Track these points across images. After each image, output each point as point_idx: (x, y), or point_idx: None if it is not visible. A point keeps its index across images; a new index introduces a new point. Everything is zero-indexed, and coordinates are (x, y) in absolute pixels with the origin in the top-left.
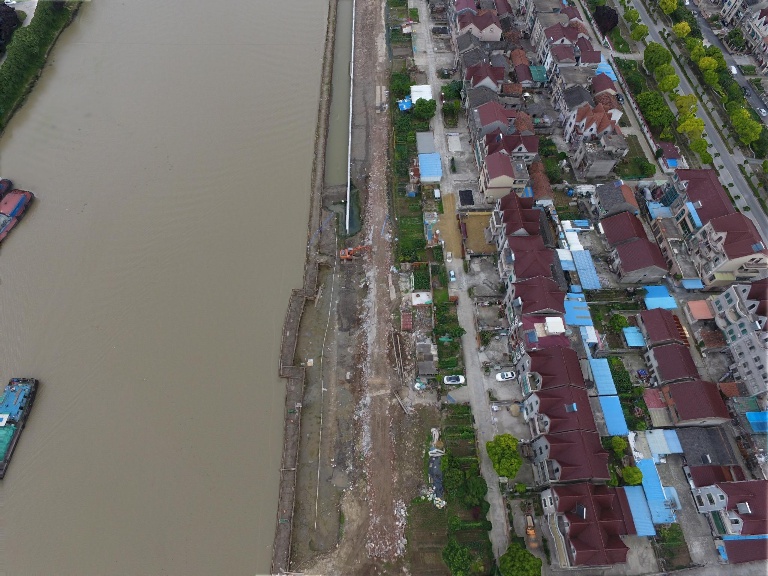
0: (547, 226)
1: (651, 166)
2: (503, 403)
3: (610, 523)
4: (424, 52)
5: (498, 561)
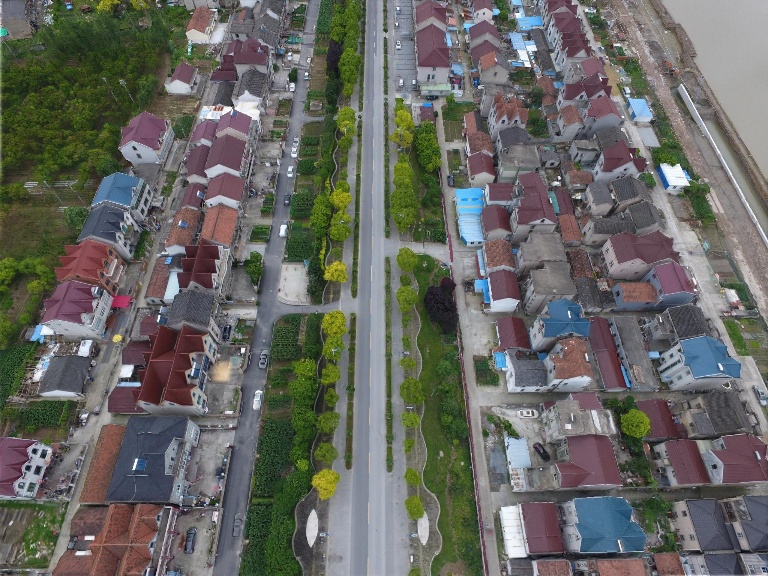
0: (544, 61)
1: None
2: None
3: None
4: (692, 252)
5: None
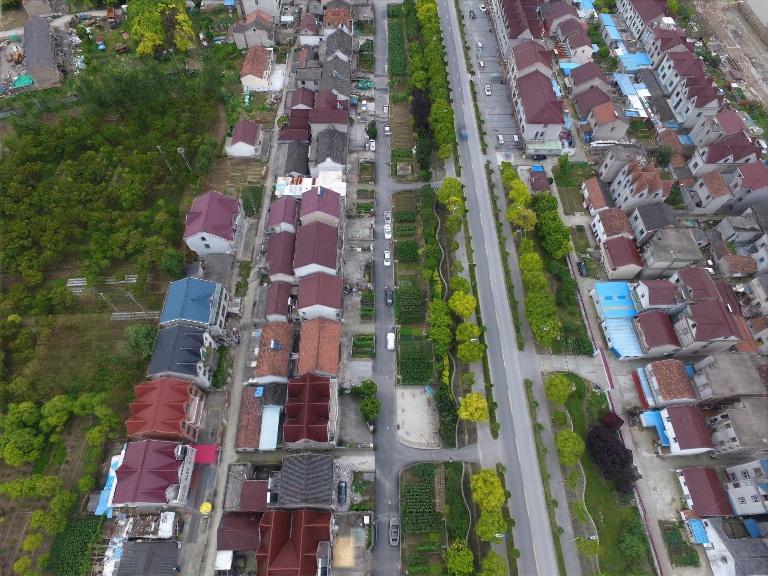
0: (662, 109)
1: None
2: None
3: None
4: None
5: None
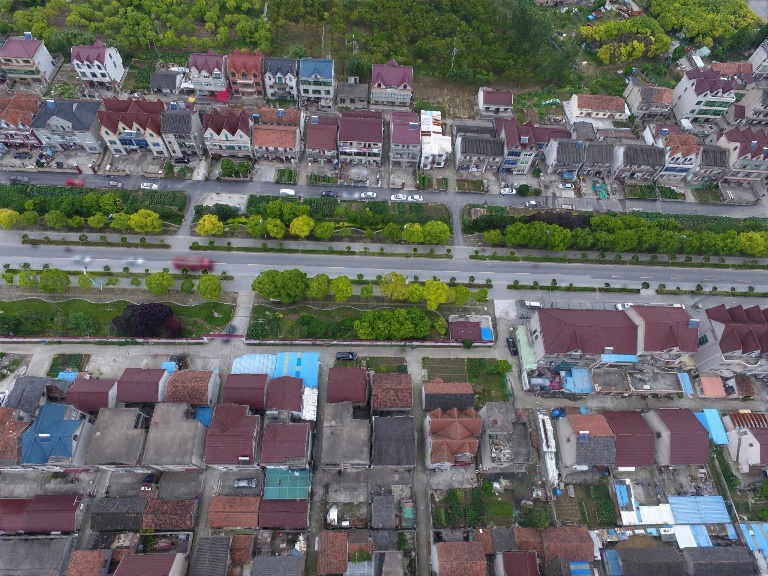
0: (646, 554)
1: (509, 368)
2: None
3: None
4: None
5: None
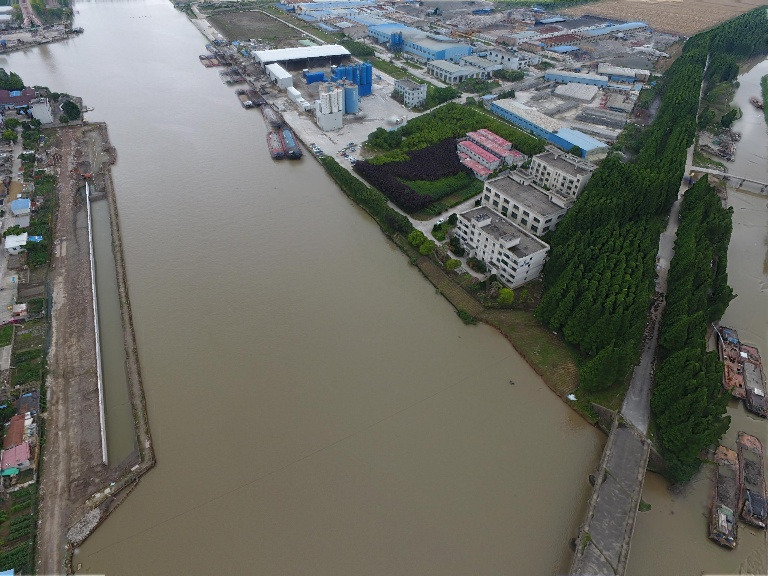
0: None
1: None
2: (6, 151)
3: None
4: (3, 289)
5: (21, 125)
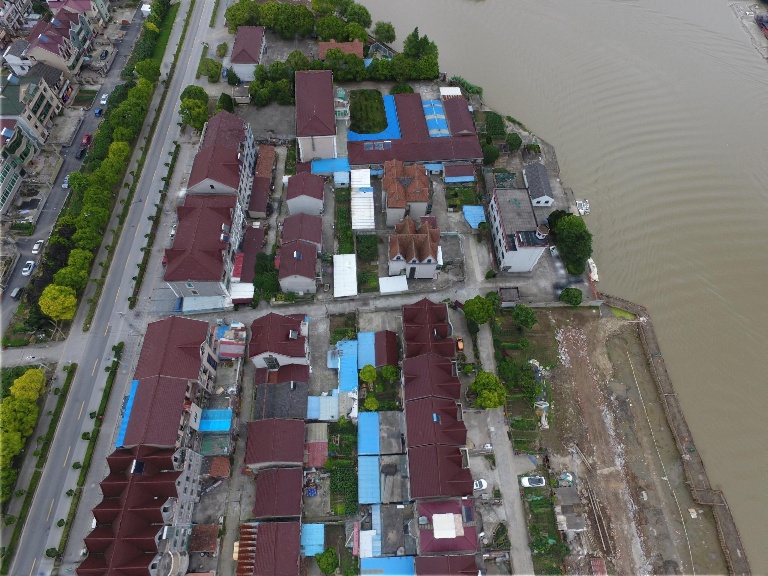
0: None
1: None
2: (480, 452)
3: (415, 325)
4: None
5: None
